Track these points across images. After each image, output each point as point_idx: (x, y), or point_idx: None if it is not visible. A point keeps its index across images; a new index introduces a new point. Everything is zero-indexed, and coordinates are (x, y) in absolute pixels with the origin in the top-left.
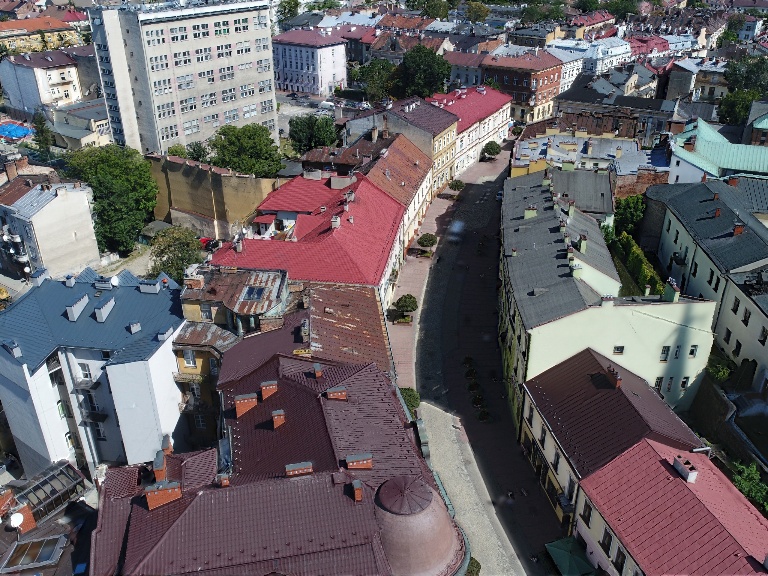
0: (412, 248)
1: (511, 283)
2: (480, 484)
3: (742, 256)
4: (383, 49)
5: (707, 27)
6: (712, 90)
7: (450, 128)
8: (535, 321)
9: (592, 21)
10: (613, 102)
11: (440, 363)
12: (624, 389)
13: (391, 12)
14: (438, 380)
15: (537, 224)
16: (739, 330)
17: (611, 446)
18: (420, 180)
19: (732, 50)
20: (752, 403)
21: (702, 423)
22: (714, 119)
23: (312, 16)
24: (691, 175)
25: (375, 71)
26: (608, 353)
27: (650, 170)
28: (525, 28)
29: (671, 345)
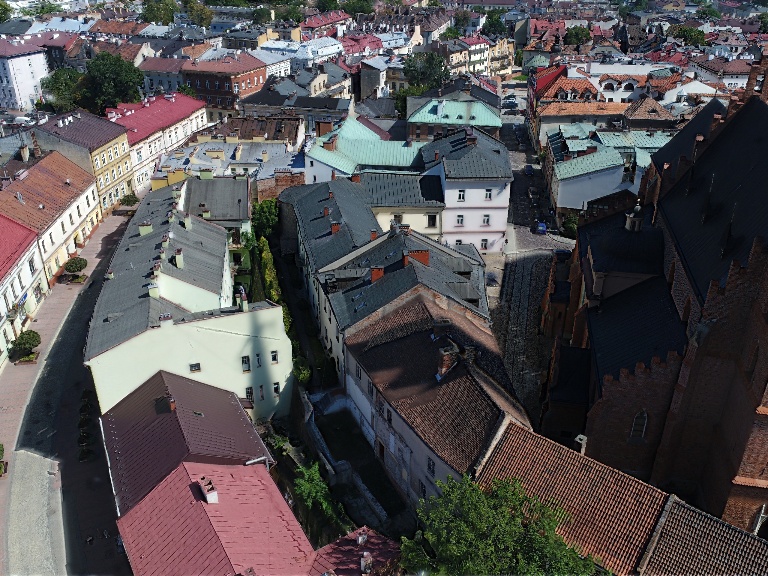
0: (65, 274)
1: (94, 310)
2: (58, 535)
3: (332, 254)
4: (78, 57)
5: (428, 24)
6: (402, 86)
7: (117, 140)
8: (96, 351)
9: (327, 21)
10: (293, 103)
11: (56, 402)
12: (182, 411)
13: (120, 16)
14: (47, 422)
15: (148, 241)
16: (329, 328)
17: (153, 476)
18: (70, 200)
19: (435, 46)
20: (334, 400)
21: (296, 426)
22: (397, 114)
23: (20, 23)
24: (326, 174)
25: (60, 82)
26: (185, 372)
27: (286, 172)
28: (238, 30)
29: (249, 355)
